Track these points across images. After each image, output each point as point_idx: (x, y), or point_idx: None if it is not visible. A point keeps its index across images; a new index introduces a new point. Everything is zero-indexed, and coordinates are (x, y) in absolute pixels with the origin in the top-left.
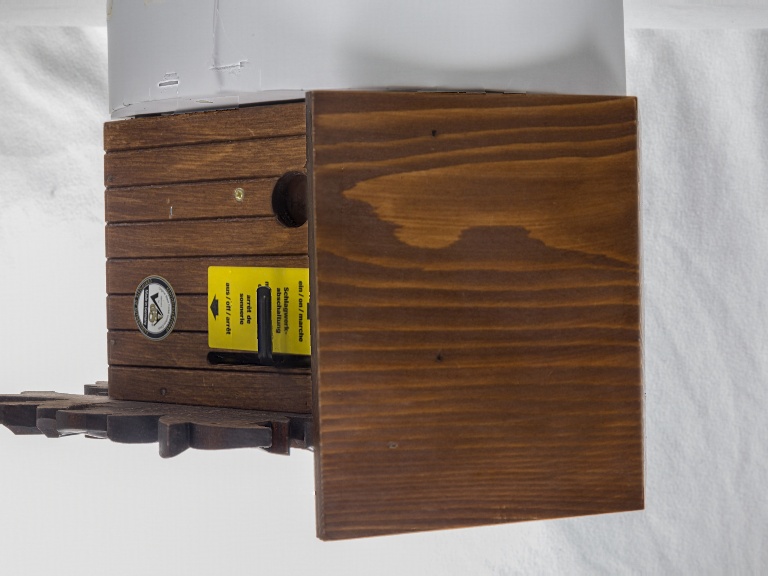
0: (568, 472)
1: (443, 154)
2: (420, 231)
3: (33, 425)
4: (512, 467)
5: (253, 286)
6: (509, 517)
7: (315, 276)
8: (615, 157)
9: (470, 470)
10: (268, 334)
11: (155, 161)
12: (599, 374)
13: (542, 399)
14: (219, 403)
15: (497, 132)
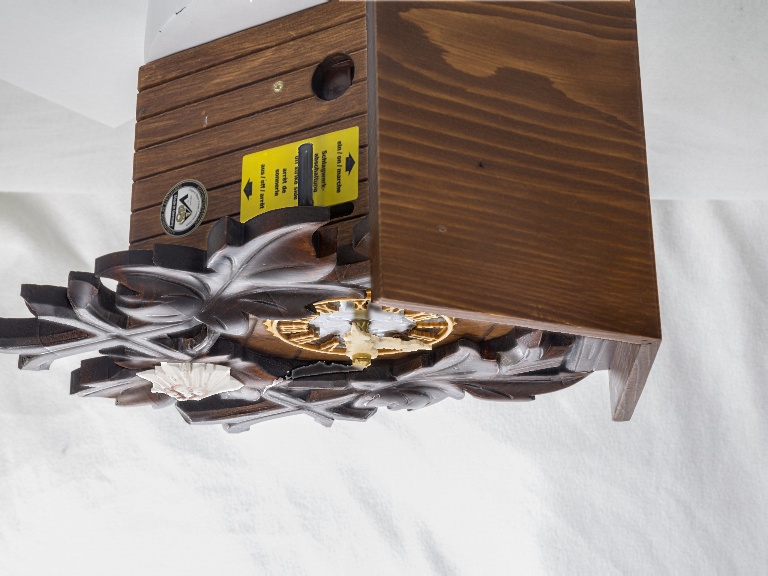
0: (594, 290)
1: (481, 4)
2: (463, 59)
3: (58, 305)
4: (546, 274)
5: (290, 159)
6: (545, 317)
7: (375, 73)
8: (620, 42)
9: (509, 267)
10: (309, 182)
11: (191, 83)
12: (616, 213)
13: (569, 222)
14: None
15: None
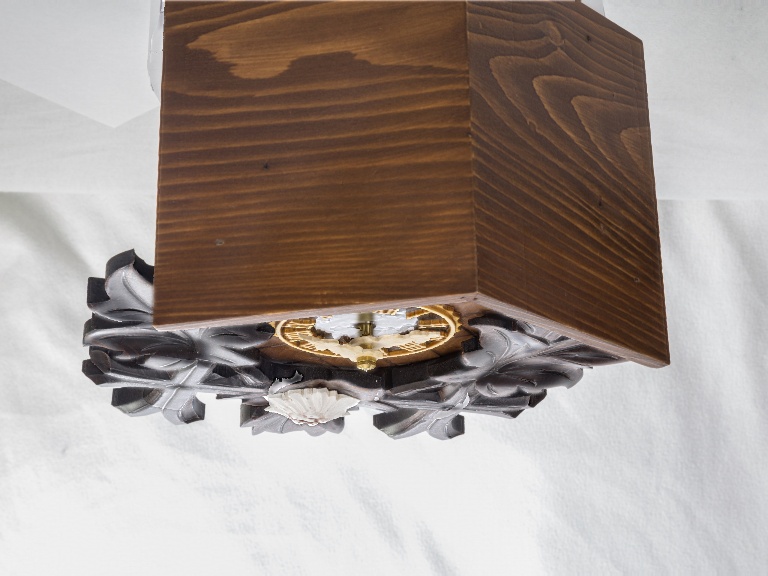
0: (393, 259)
1: (276, 4)
2: (253, 66)
3: None
4: (334, 257)
5: None
6: (330, 302)
7: None
8: None
9: (292, 261)
10: None
11: None
12: (426, 169)
13: (366, 195)
14: None
15: None
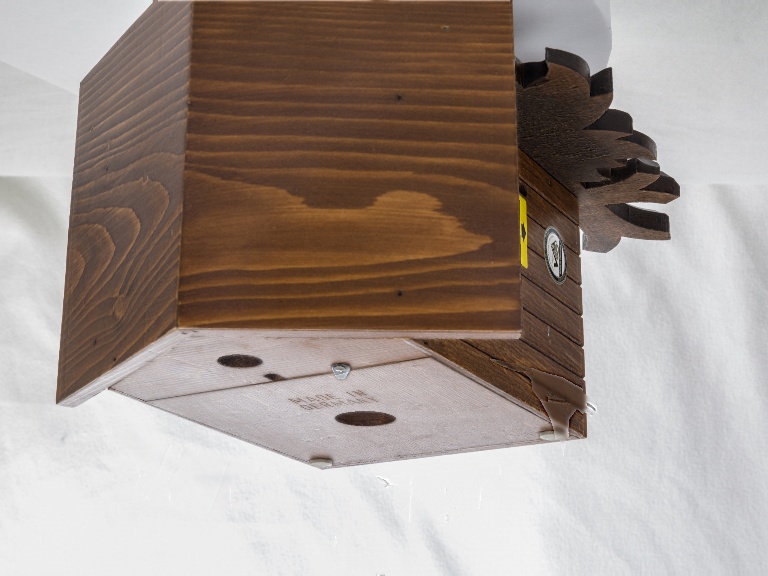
0: None
1: (391, 274)
2: (416, 206)
3: None
4: (330, 3)
5: None
6: None
7: None
8: (205, 270)
9: (372, 3)
10: None
11: None
12: (235, 75)
13: (296, 57)
14: (520, 151)
15: (334, 294)
